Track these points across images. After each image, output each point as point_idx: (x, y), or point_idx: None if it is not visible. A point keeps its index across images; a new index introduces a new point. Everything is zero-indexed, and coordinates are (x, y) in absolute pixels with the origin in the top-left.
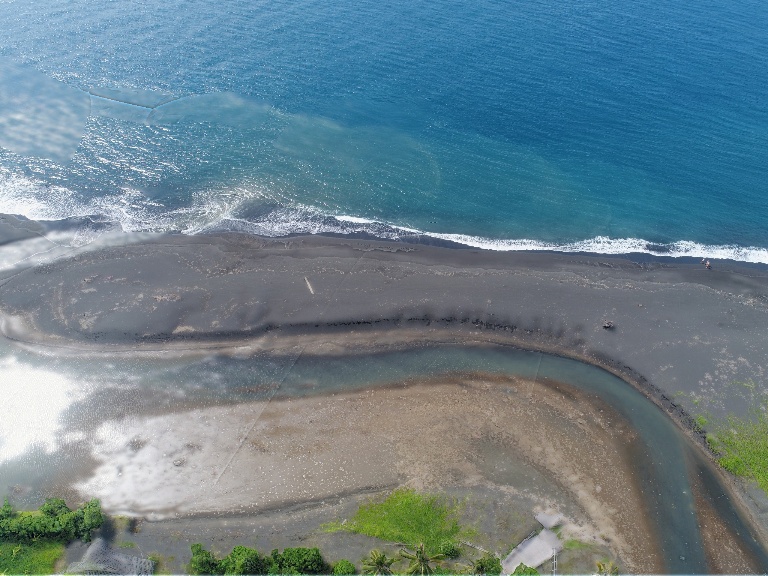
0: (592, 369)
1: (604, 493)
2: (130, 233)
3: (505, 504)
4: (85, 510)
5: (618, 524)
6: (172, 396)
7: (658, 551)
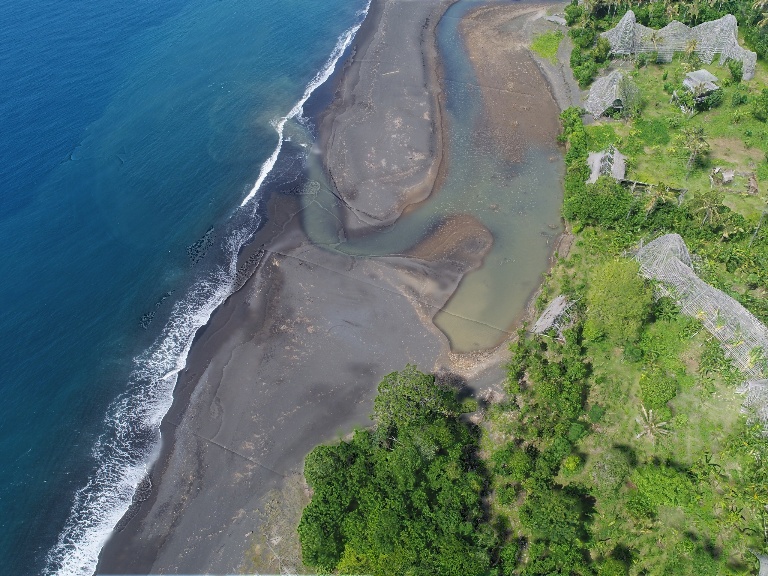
0: (454, 6)
1: (522, 8)
2: (309, 161)
3: (534, 24)
4: (570, 111)
5: (536, 7)
6: (479, 118)
7: (545, 2)
